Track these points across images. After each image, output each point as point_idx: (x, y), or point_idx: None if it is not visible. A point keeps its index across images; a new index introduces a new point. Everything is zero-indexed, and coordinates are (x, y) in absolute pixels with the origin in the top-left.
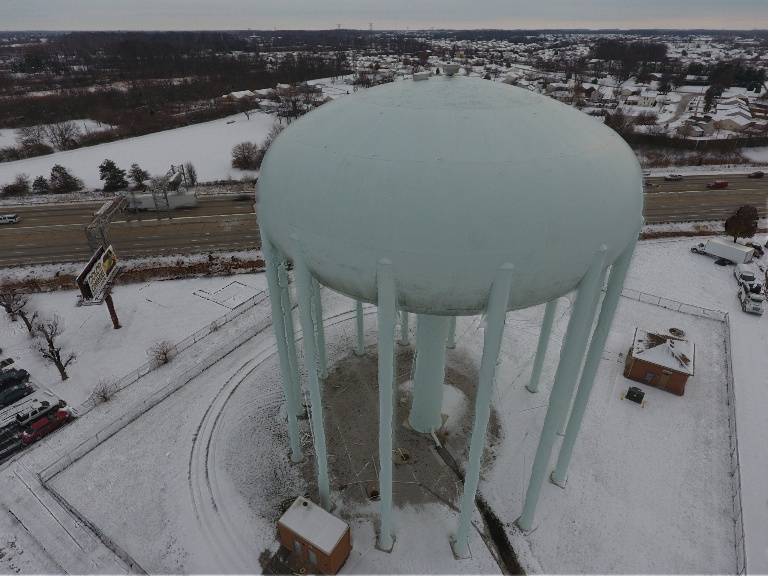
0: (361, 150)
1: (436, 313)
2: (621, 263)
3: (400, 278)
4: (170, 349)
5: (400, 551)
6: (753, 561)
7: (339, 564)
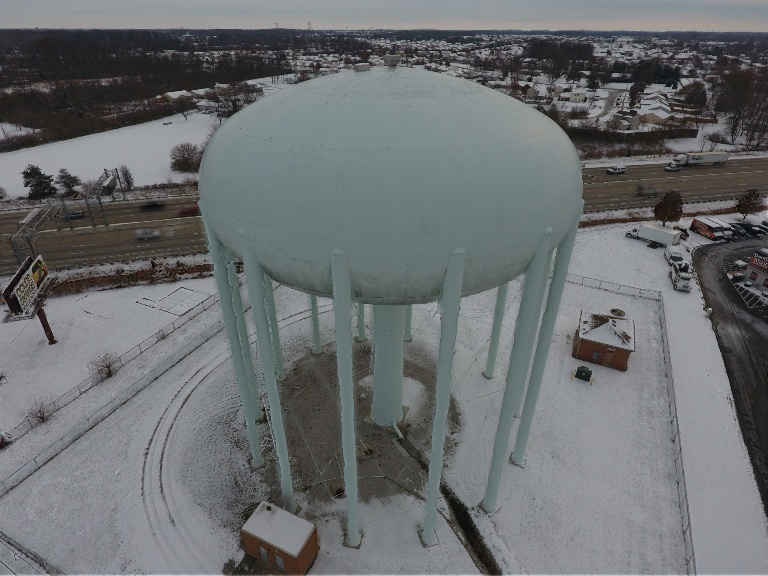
0: (308, 140)
1: (392, 302)
2: (565, 245)
3: (355, 268)
4: (114, 361)
5: (368, 546)
6: (696, 518)
7: (307, 566)
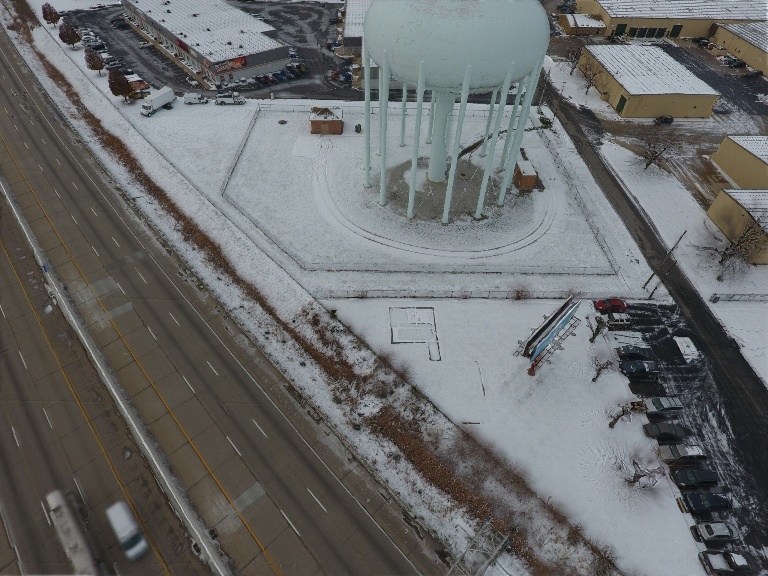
0: None
1: None
2: None
3: None
4: None
5: None
6: None
7: None
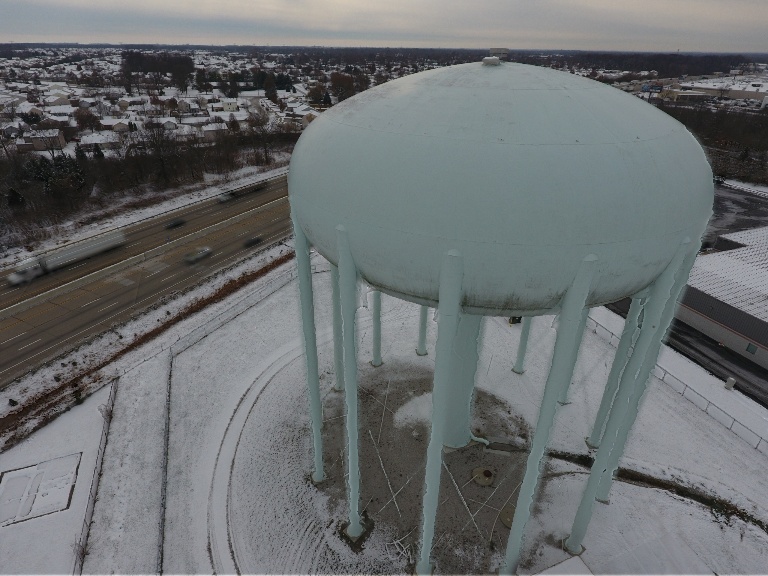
0: (619, 135)
1: None
2: None
3: None
4: None
5: (587, 540)
6: None
7: None
